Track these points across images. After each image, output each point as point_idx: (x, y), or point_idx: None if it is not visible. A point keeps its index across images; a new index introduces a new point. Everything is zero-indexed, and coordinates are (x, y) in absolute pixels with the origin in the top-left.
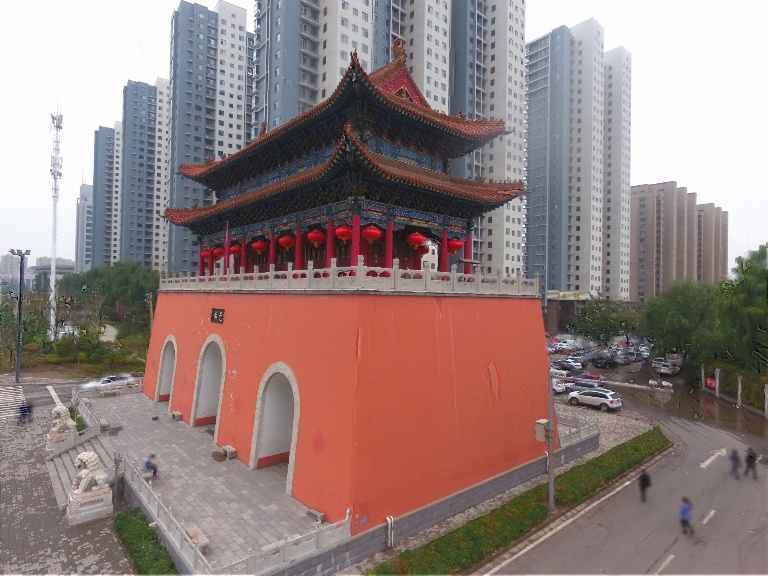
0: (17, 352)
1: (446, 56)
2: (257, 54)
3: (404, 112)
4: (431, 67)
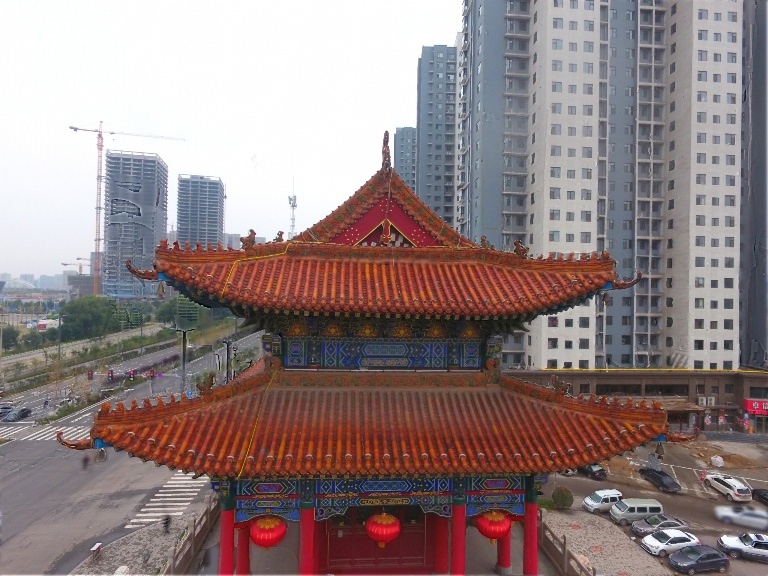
0: None
1: (736, 10)
2: (464, 90)
3: (309, 312)
4: (707, 35)
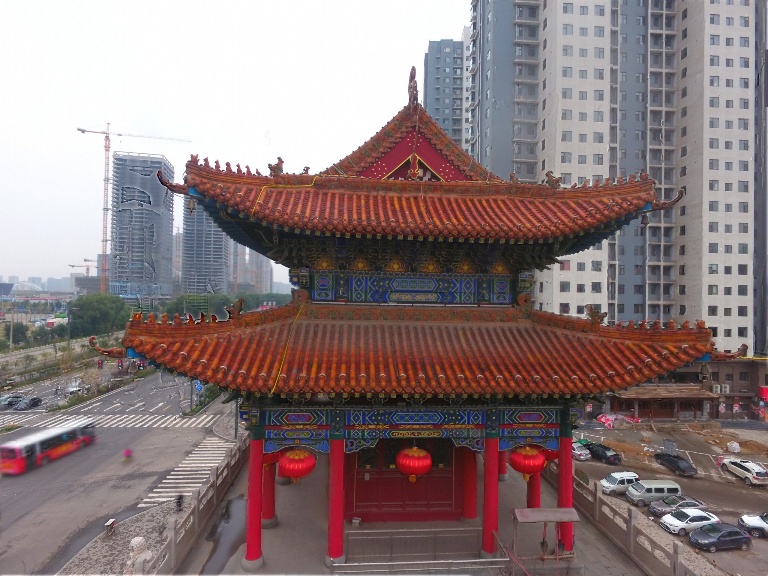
0: (236, 412)
1: None
2: (473, 79)
3: (340, 233)
4: (719, 20)
